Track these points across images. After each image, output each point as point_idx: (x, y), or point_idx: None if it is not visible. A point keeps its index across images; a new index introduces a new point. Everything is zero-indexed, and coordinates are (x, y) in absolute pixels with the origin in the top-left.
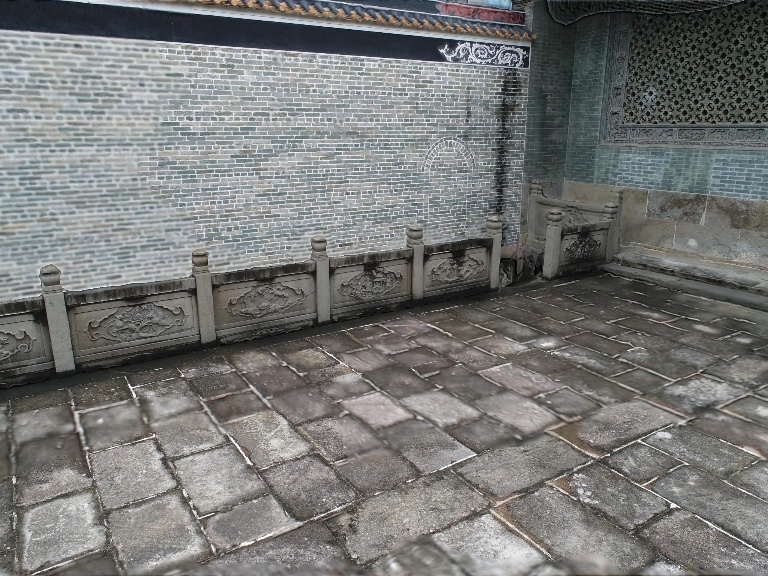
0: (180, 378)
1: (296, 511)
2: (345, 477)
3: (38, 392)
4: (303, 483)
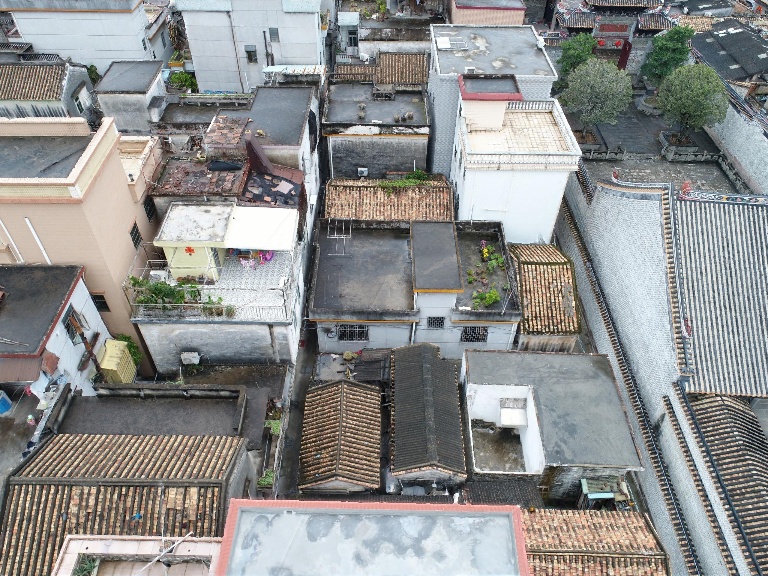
0: None
1: None
2: None
3: (733, 188)
4: None
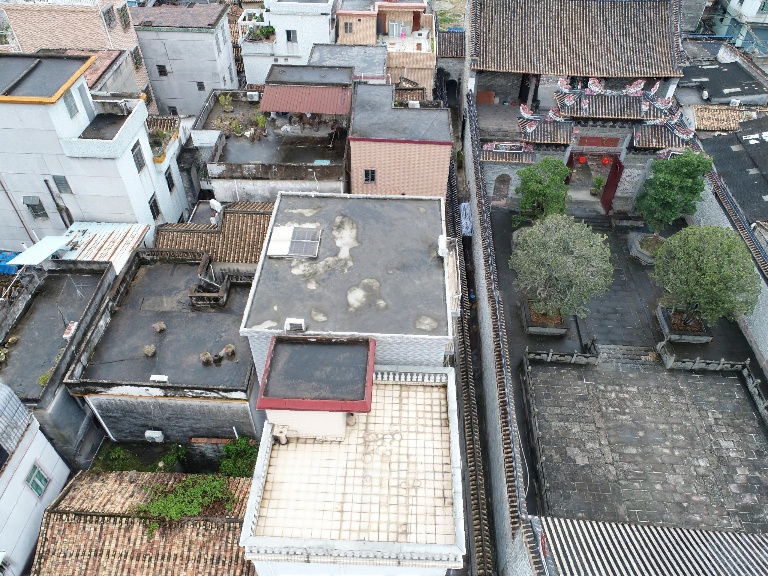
0: (764, 450)
1: (716, 449)
2: (723, 457)
3: (763, 431)
4: (723, 452)
